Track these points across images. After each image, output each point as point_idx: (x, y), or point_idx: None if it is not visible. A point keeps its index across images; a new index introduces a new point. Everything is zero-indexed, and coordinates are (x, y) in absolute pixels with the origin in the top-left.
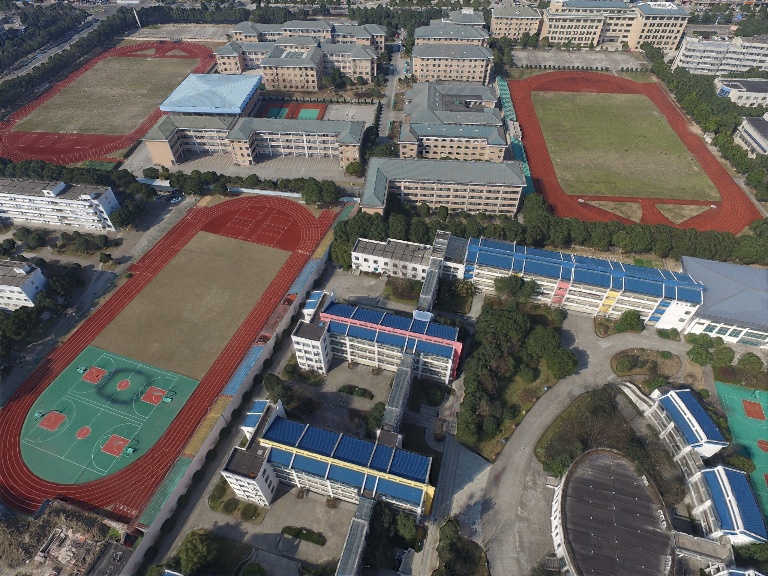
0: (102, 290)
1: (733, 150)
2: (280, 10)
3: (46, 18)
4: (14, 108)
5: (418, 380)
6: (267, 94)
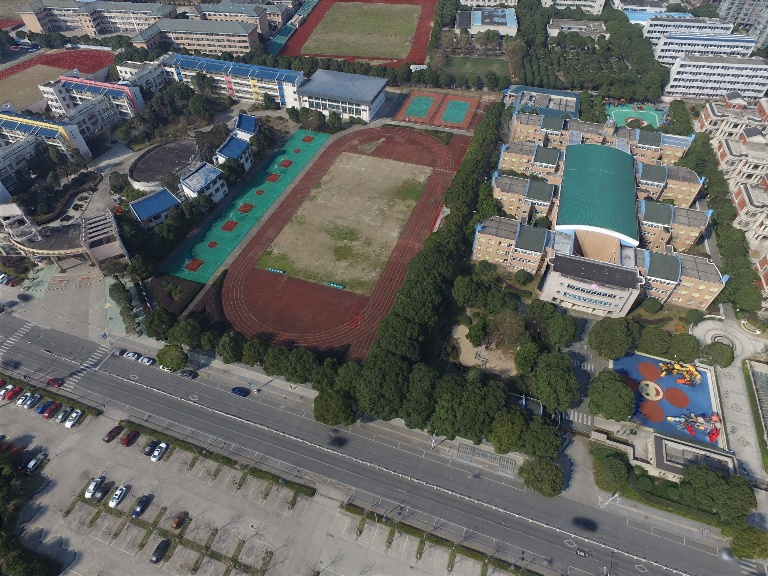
0: None
1: None
2: None
3: None
4: None
5: None
6: None
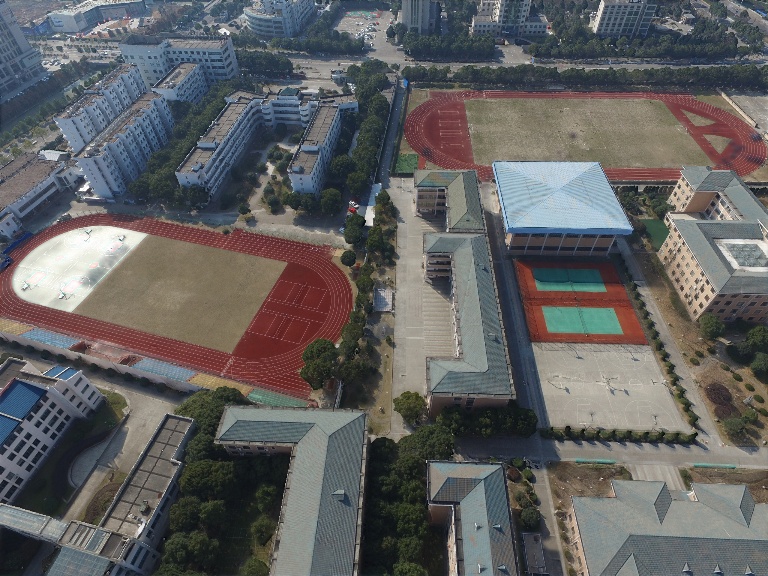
0: (213, 222)
1: None
2: None
3: (702, 35)
4: (507, 88)
5: None
6: (642, 257)
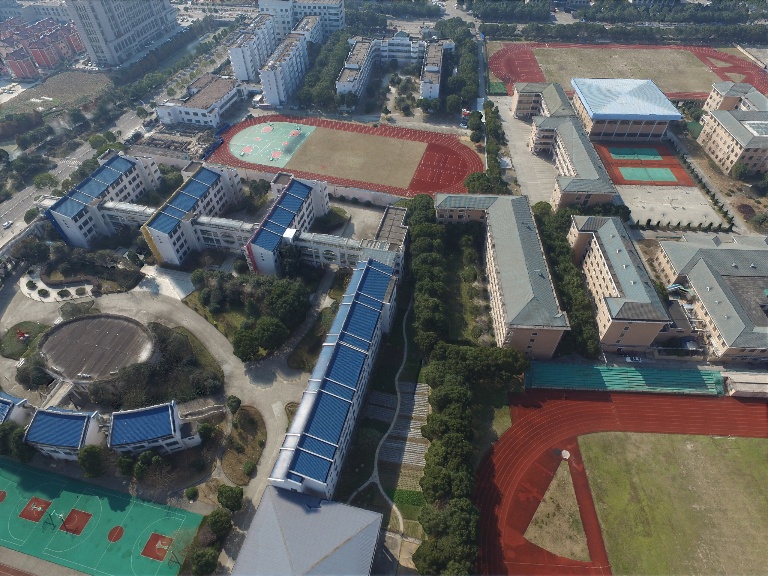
0: (362, 120)
1: None
2: None
3: None
4: (564, 41)
5: None
6: (686, 142)
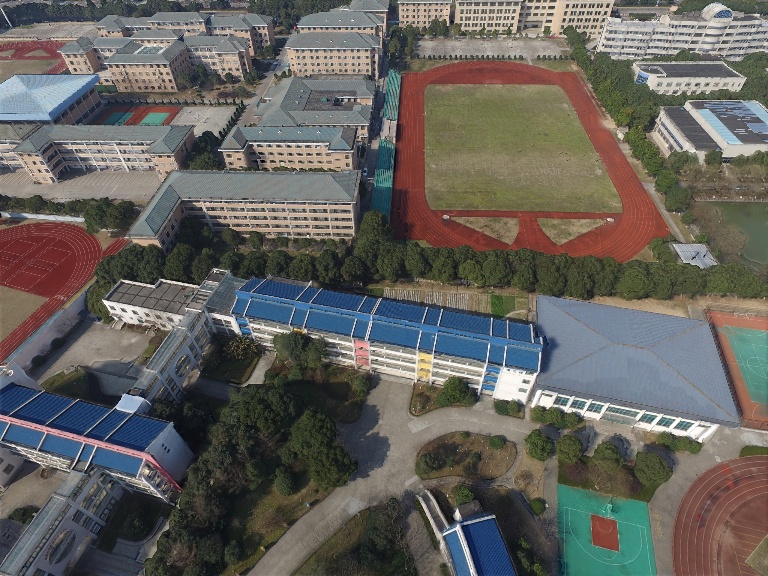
0: None
1: (643, 148)
2: (166, 3)
3: None
4: None
5: (130, 495)
6: (117, 97)
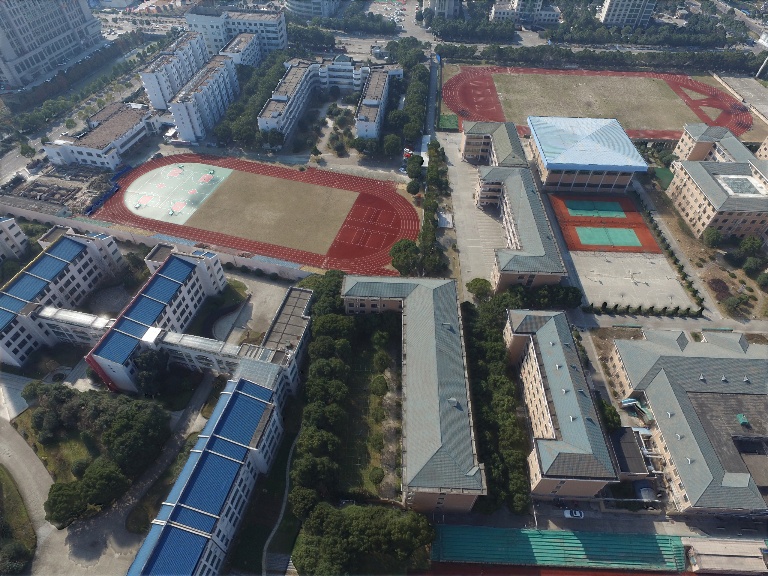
0: (288, 162)
1: None
2: None
3: None
4: (528, 65)
5: None
6: (653, 194)
